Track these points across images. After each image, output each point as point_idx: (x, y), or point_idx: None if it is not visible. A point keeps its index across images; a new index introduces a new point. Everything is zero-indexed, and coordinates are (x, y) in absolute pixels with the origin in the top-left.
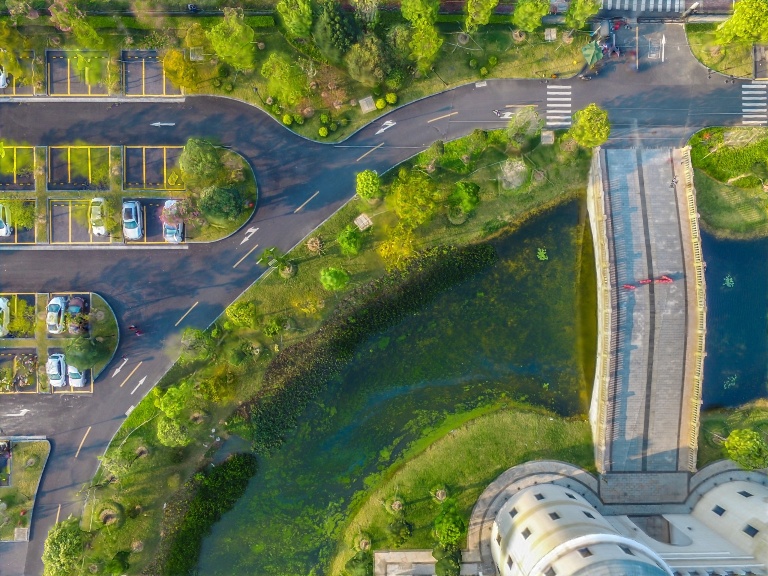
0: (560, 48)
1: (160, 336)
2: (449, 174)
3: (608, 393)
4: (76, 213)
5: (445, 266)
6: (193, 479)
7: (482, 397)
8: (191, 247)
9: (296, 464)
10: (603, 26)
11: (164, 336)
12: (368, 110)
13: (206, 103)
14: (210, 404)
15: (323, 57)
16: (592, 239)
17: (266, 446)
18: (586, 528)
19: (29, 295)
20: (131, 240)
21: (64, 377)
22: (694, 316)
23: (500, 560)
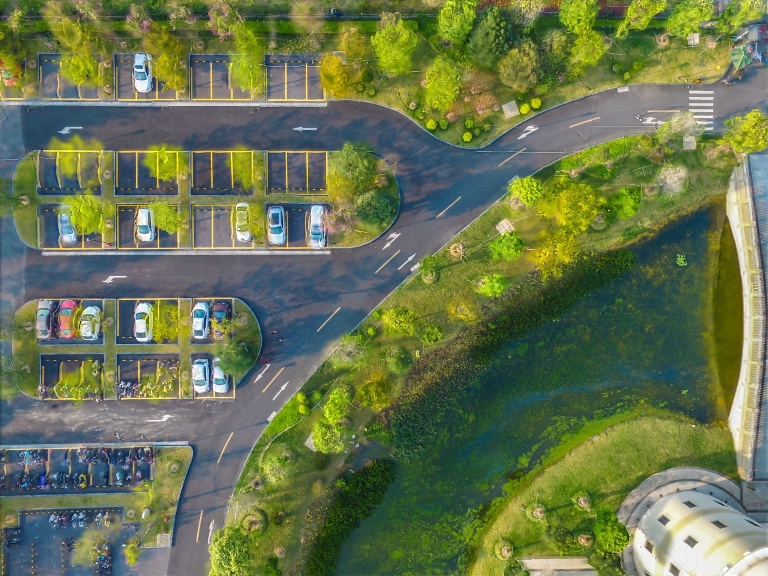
0: (703, 53)
1: (302, 342)
2: (592, 179)
3: (756, 400)
4: (218, 218)
5: (585, 272)
6: (333, 485)
7: (621, 403)
8: (333, 252)
9: (435, 470)
10: (752, 31)
11: (306, 342)
12: (511, 115)
13: (348, 108)
14: (352, 410)
15: (468, 62)
16: (735, 245)
17: (406, 452)
18: (762, 537)
19: (171, 300)
20: (274, 245)
21: (208, 383)
22: None
23: (656, 568)
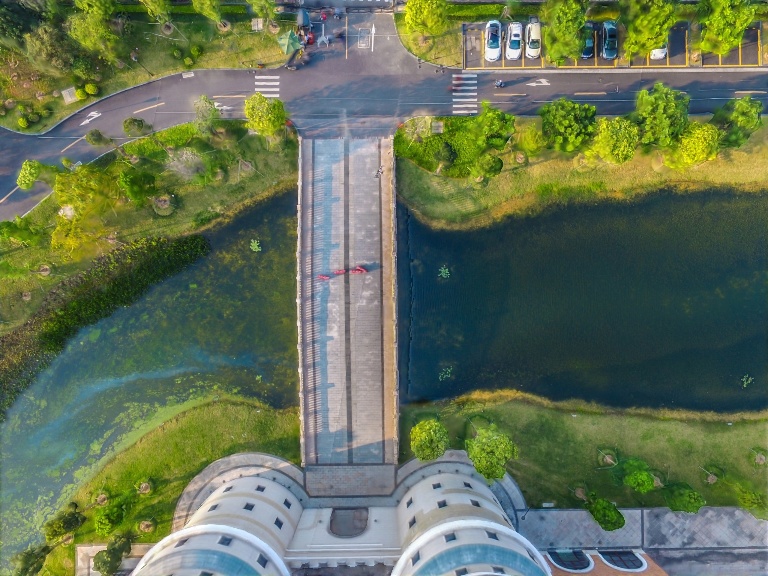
0: (266, 38)
1: None
2: (153, 165)
3: None
4: None
5: (154, 258)
6: None
7: (194, 389)
8: None
9: (5, 457)
10: (299, 15)
11: None
12: (71, 101)
13: None
14: None
15: None
16: None
17: None
18: (221, 519)
19: None
20: None
21: None
22: (389, 307)
23: None
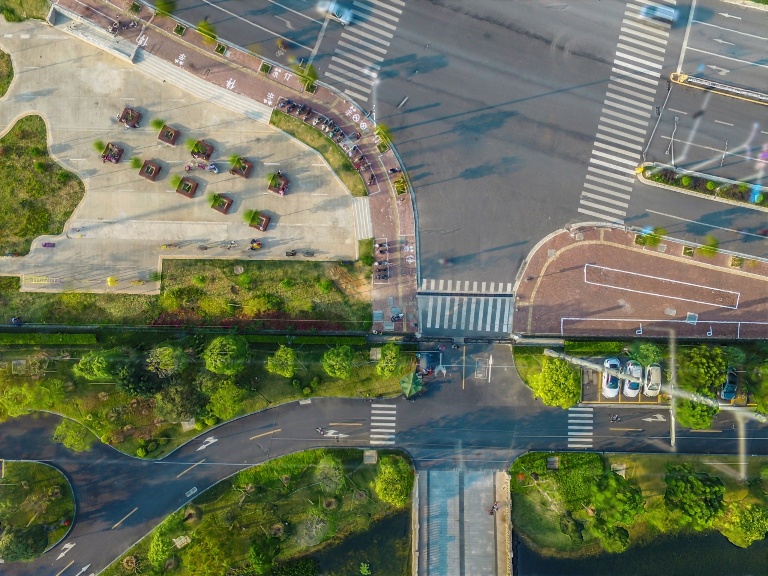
0: None
1: None
2: (269, 494)
3: None
4: None
5: None
6: None
7: None
8: None
9: None
10: (422, 359)
11: None
12: (189, 428)
13: (27, 417)
14: None
15: None
16: (412, 562)
17: None
18: None
19: None
20: None
21: None
22: None
23: None
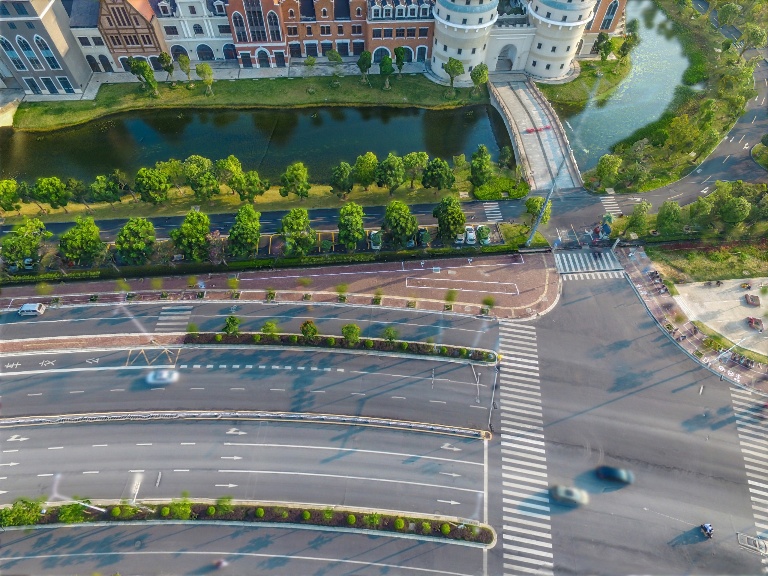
0: None
1: (760, 113)
2: (658, 172)
3: None
4: None
5: None
6: None
7: (591, 104)
8: None
9: None
10: None
11: (759, 113)
12: None
13: None
14: None
15: None
16: None
17: None
18: (565, 36)
19: None
20: None
21: None
22: None
23: None
